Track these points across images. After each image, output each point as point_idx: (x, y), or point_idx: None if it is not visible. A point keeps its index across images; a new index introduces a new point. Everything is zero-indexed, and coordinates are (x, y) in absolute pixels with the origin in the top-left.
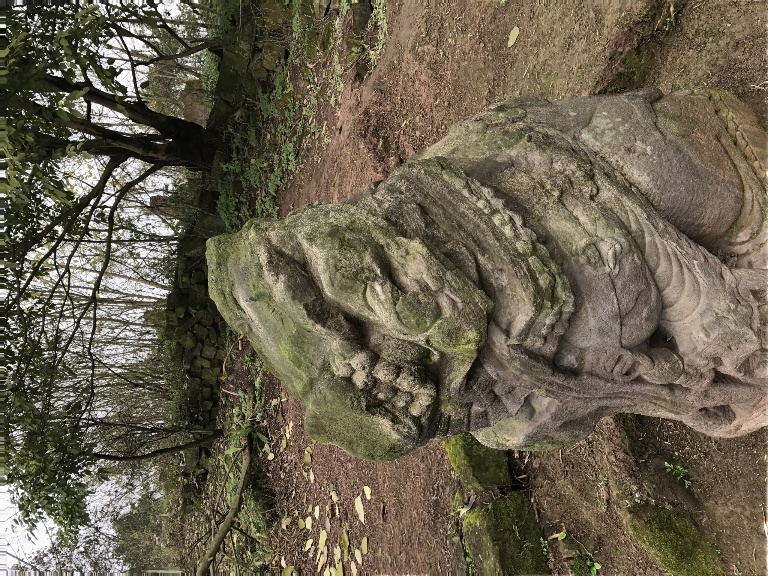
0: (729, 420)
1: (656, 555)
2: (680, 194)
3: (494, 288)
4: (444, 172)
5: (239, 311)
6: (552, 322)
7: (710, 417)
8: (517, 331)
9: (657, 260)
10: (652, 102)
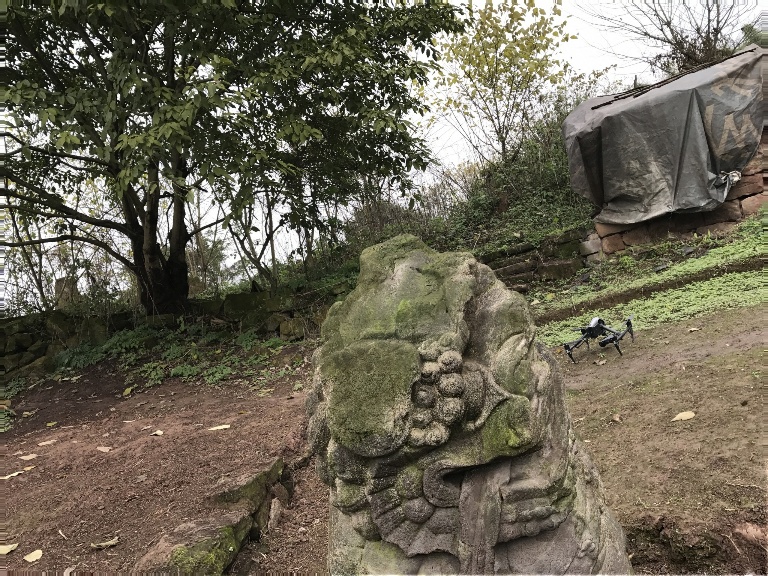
0: None
1: None
2: None
3: None
4: None
5: (390, 268)
6: (540, 513)
7: None
8: (518, 488)
9: None
10: (626, 548)
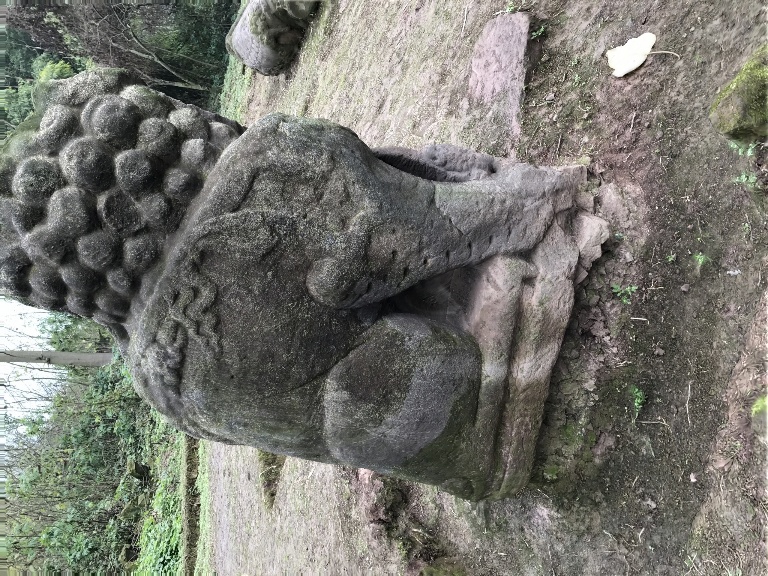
0: None
1: (764, 47)
2: None
3: None
4: None
5: None
6: None
7: None
8: None
9: None
10: None
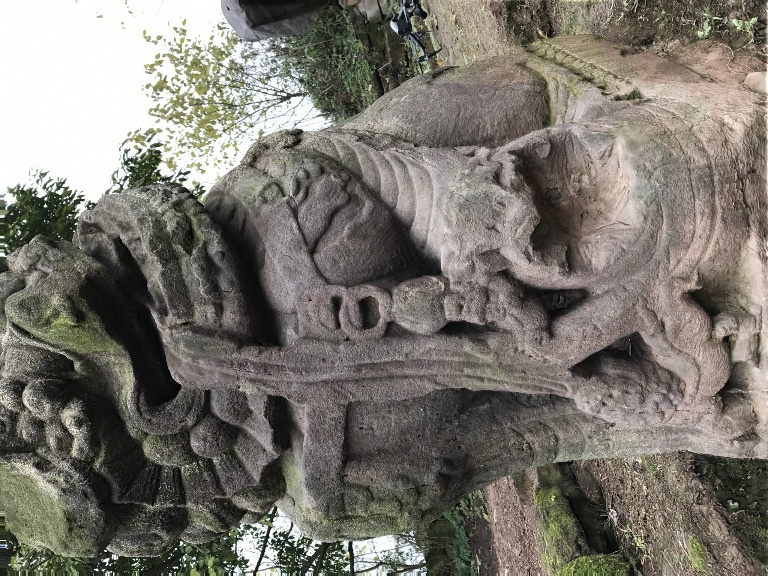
0: (660, 383)
1: None
2: (439, 116)
3: (138, 263)
4: (129, 189)
5: None
6: (199, 272)
7: (609, 383)
8: None
9: (375, 174)
10: (438, 73)
